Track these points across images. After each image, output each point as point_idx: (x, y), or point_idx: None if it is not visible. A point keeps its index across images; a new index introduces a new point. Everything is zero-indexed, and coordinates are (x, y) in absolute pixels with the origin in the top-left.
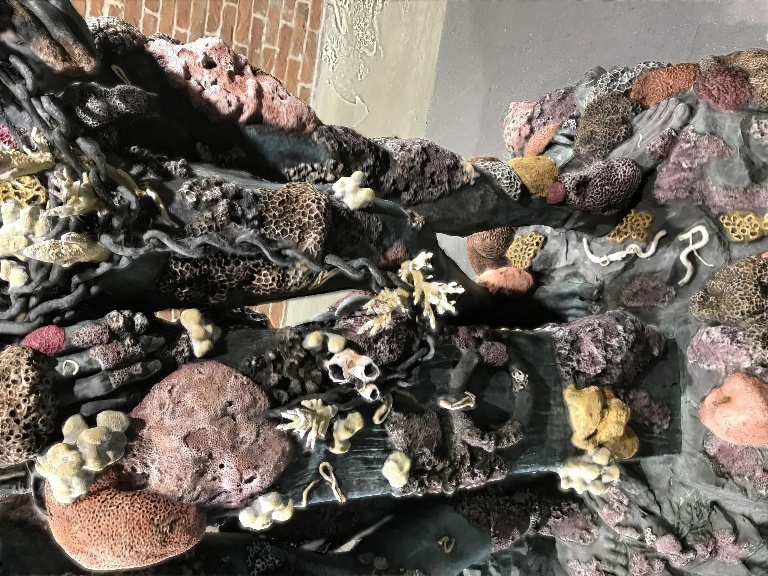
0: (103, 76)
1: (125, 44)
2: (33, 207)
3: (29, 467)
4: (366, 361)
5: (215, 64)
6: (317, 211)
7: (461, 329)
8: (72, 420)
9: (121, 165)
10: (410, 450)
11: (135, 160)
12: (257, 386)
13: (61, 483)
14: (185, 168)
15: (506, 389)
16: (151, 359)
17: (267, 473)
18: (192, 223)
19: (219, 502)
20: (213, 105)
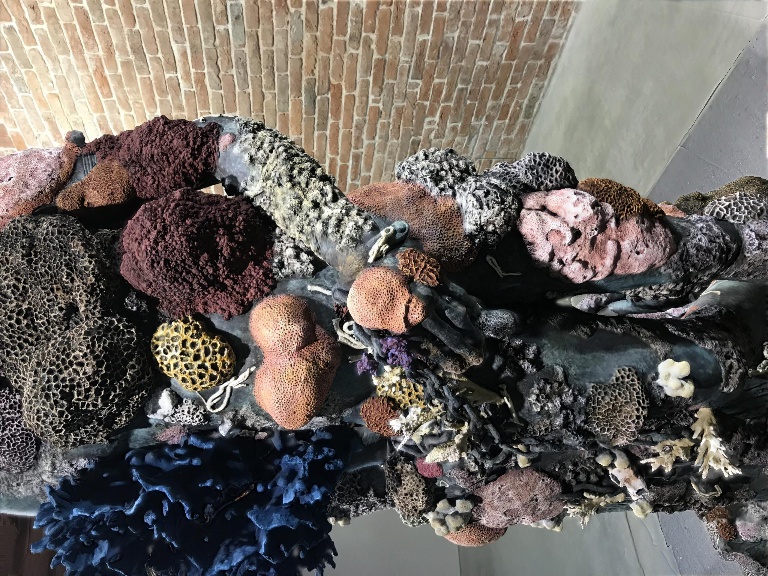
0: (478, 266)
1: (501, 238)
2: (431, 428)
3: None
4: (640, 487)
5: (580, 233)
6: (634, 430)
7: (736, 436)
8: (443, 503)
9: (486, 356)
10: (655, 501)
11: (497, 351)
12: (556, 482)
13: None
14: (535, 366)
15: (757, 466)
16: (491, 475)
17: None
18: (534, 425)
19: None
20: (569, 279)
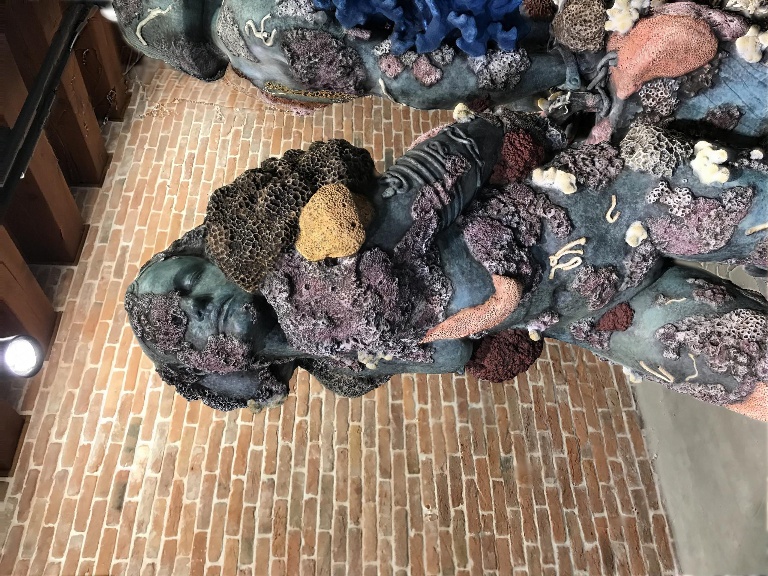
0: None
1: None
2: None
3: (591, 81)
4: None
5: None
6: None
7: None
8: None
9: None
10: None
11: None
12: None
13: (624, 12)
14: None
15: None
16: None
17: (741, 20)
18: None
19: (718, 30)
20: None
